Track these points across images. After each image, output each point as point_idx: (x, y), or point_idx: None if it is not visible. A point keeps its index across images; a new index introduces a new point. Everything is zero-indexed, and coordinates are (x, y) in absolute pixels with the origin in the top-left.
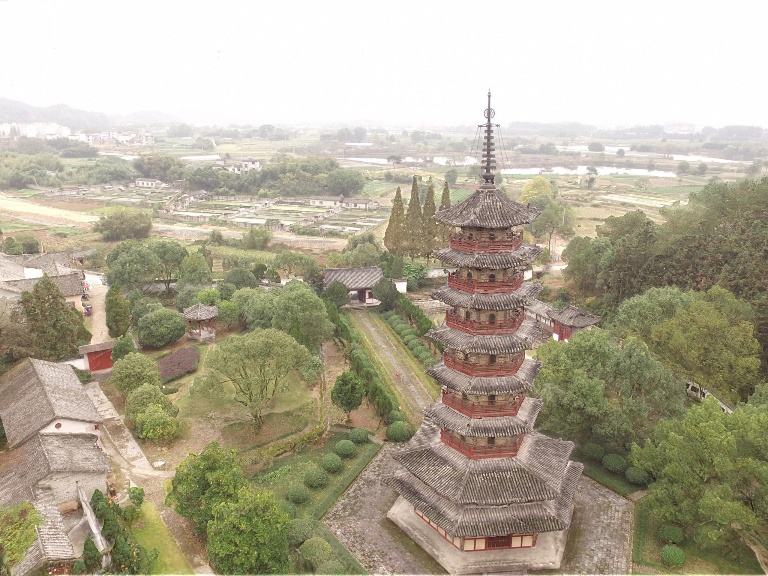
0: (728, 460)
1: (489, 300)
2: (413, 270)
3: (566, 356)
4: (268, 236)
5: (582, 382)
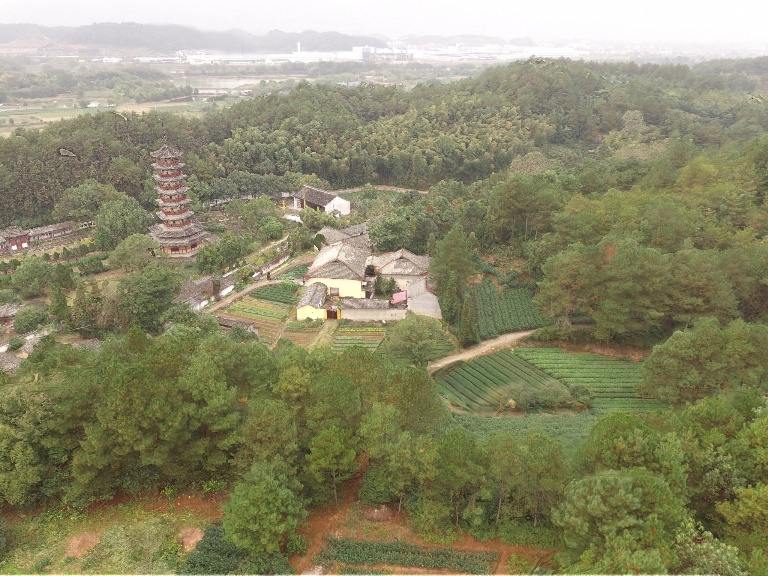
0: None
1: None
2: None
3: None
4: None
5: None
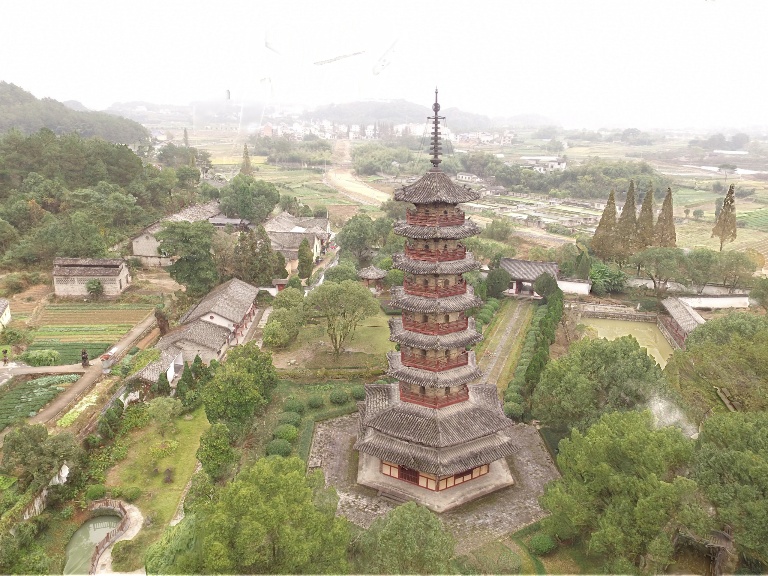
0: (583, 459)
1: (416, 265)
2: (608, 275)
3: (579, 354)
4: (509, 229)
5: (567, 377)
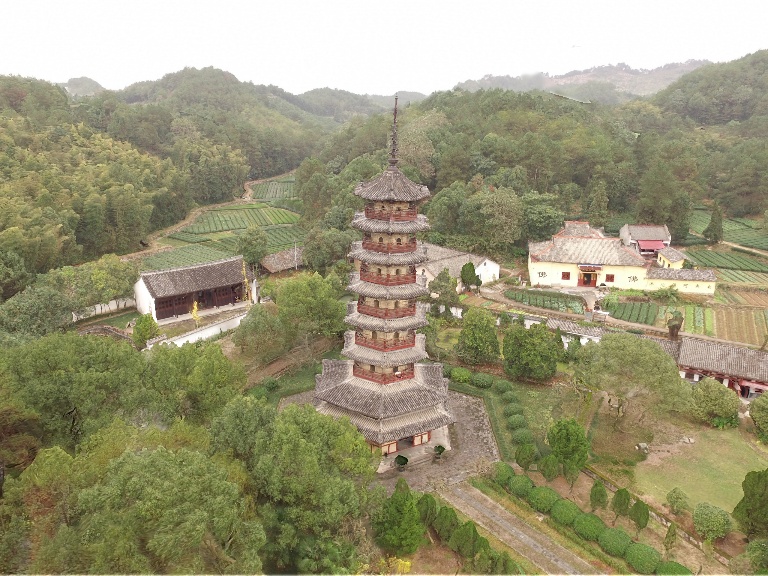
0: None
1: None
2: None
3: None
4: None
5: None
